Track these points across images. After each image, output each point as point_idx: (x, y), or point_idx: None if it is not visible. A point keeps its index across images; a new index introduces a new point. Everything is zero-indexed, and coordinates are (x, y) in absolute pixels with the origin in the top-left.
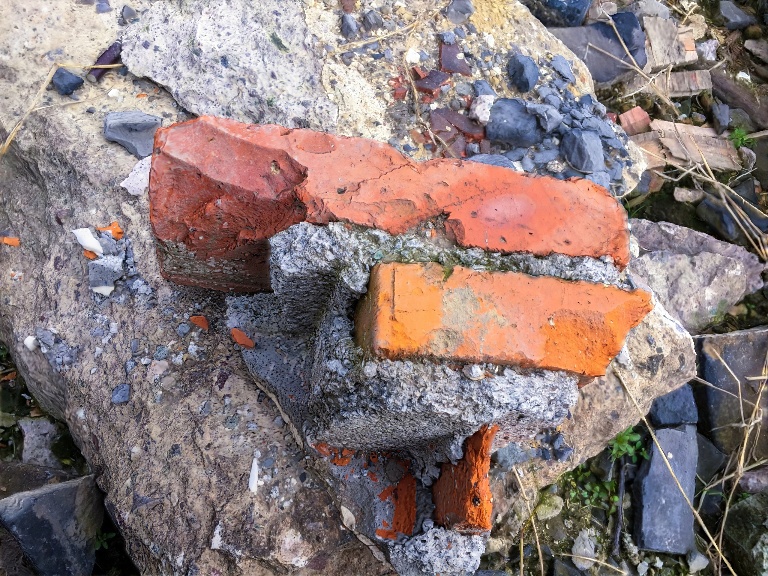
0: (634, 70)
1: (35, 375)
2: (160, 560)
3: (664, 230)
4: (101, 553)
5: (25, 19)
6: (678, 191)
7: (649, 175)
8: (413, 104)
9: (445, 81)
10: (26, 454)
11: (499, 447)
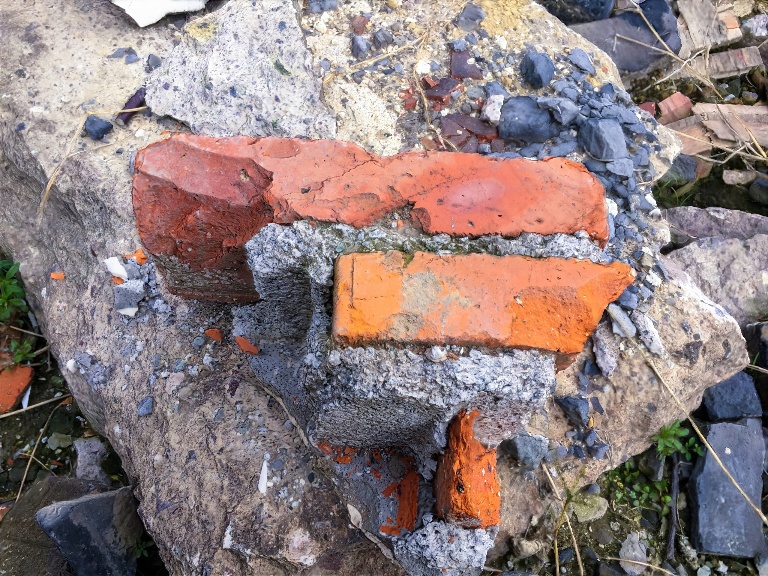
0: (667, 55)
1: (79, 396)
2: (181, 562)
3: (713, 215)
4: (142, 561)
5: (63, 77)
6: (727, 174)
7: (695, 161)
8: (423, 113)
9: (455, 87)
10: (79, 471)
11: (501, 438)
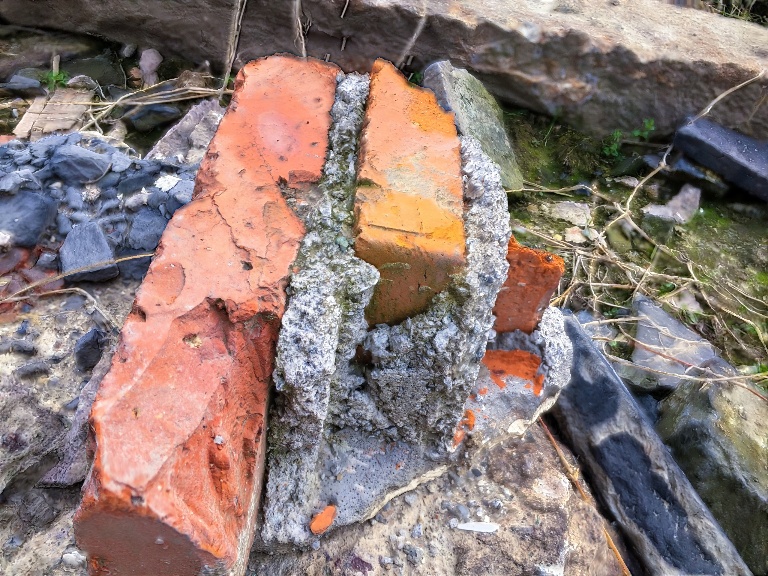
0: None
1: None
2: None
3: None
4: None
5: None
6: None
7: None
8: None
9: None
10: None
11: None
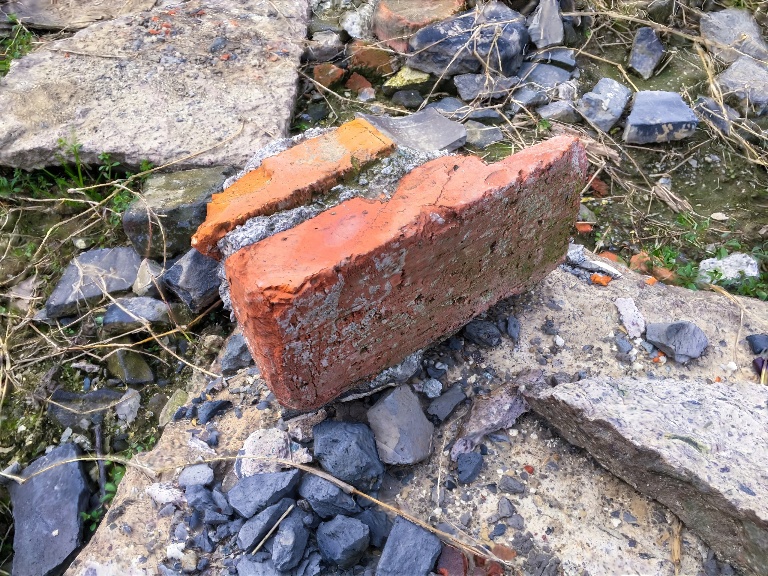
0: None
1: None
2: None
3: None
4: None
5: None
6: None
7: None
8: None
9: None
10: None
11: None
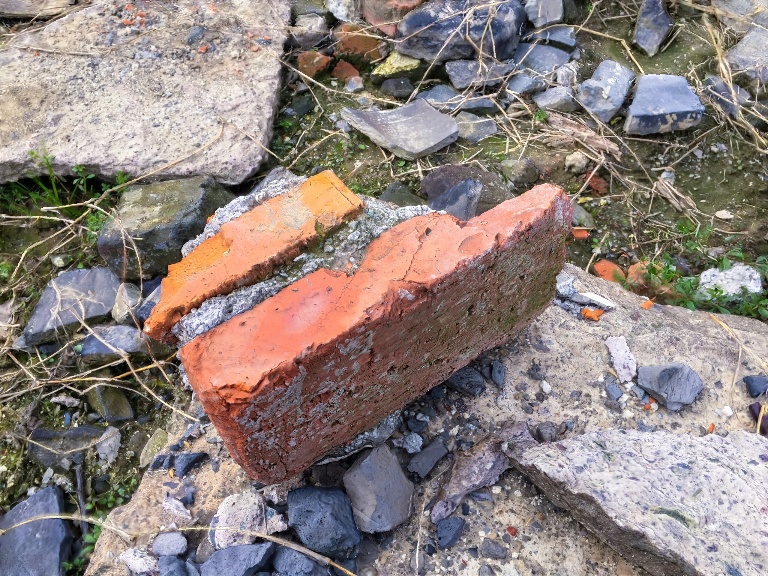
0: None
1: None
2: None
3: None
4: None
5: None
6: None
7: None
8: None
9: None
10: None
11: None
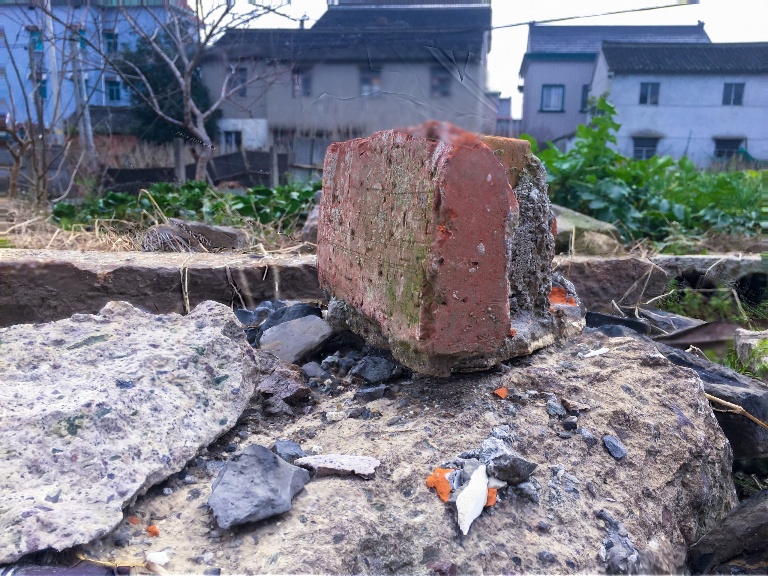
0: None
1: None
2: None
3: None
4: None
5: None
6: None
7: None
8: None
9: None
10: None
11: None
